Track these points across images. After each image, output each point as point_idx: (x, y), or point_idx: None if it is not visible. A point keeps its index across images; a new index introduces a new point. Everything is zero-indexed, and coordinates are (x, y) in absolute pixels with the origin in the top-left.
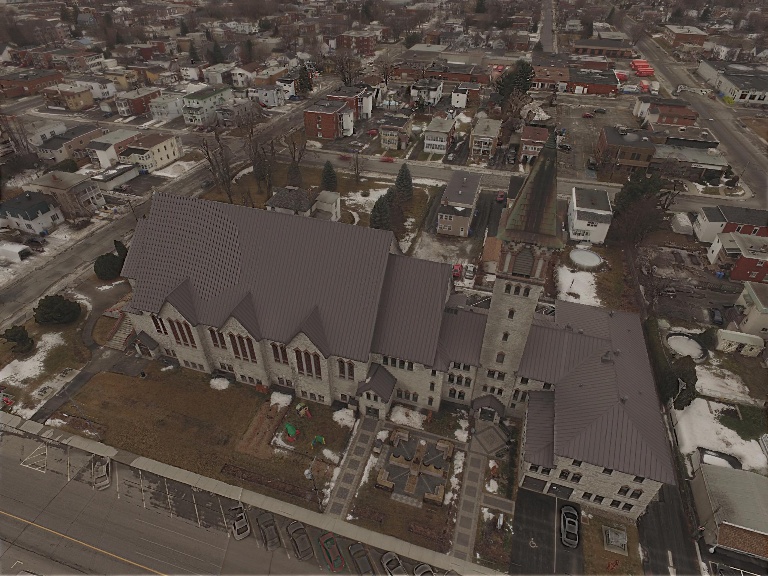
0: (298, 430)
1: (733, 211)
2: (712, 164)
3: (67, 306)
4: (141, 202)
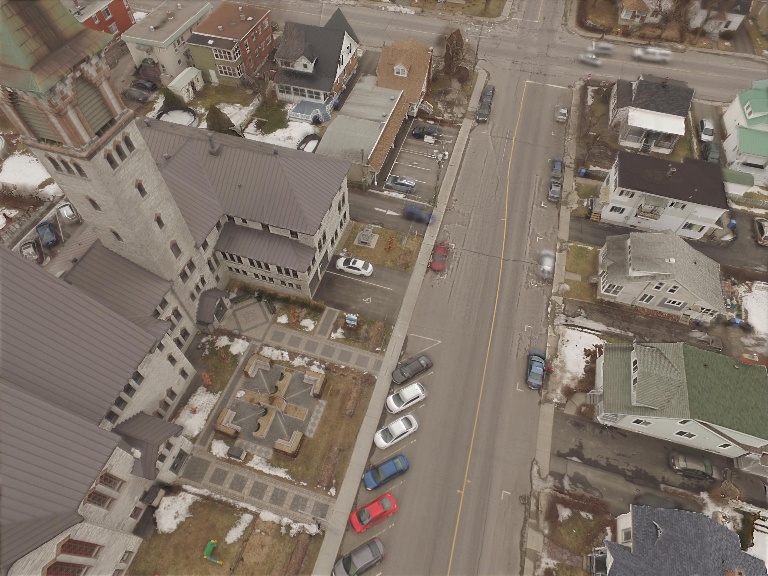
0: None
1: None
2: None
3: None
4: None
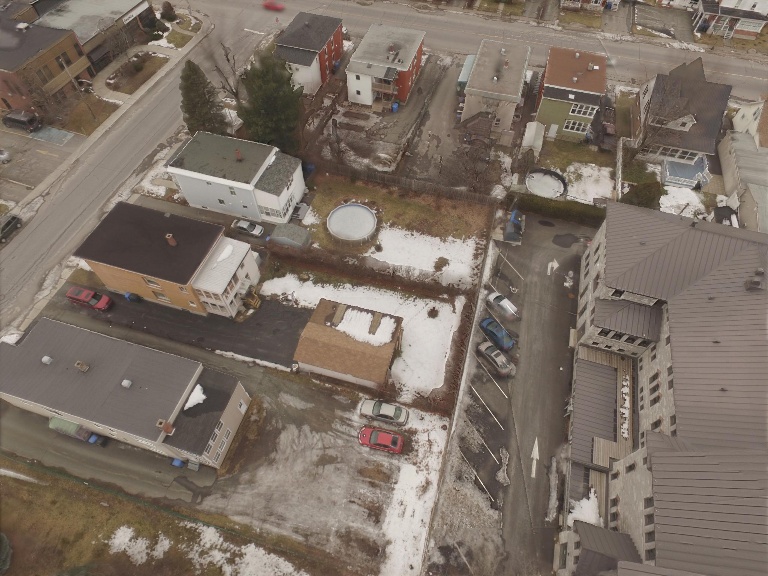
0: None
1: (301, 37)
2: (136, 5)
3: None
4: None
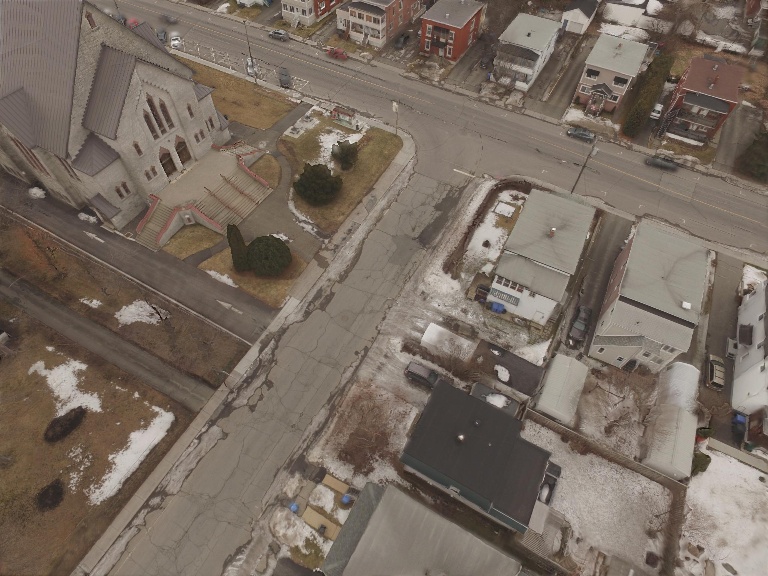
0: None
1: None
2: None
3: None
4: (234, 571)
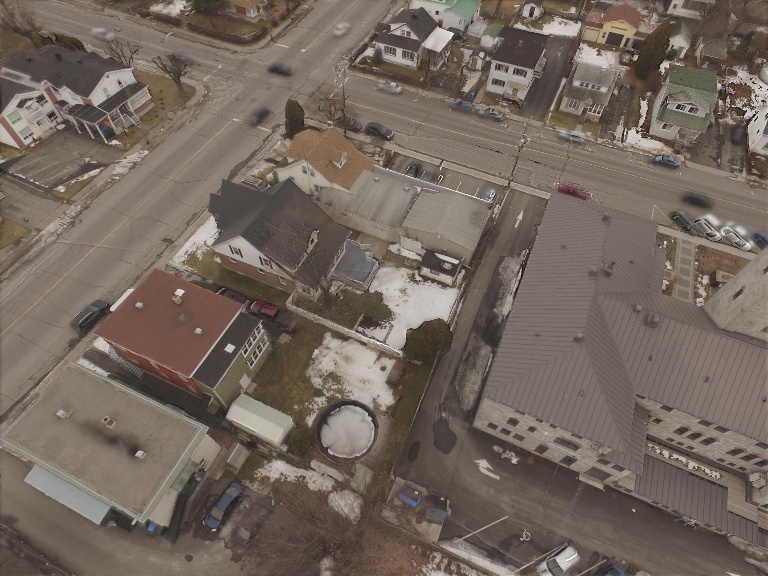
0: None
1: None
2: None
3: None
4: None
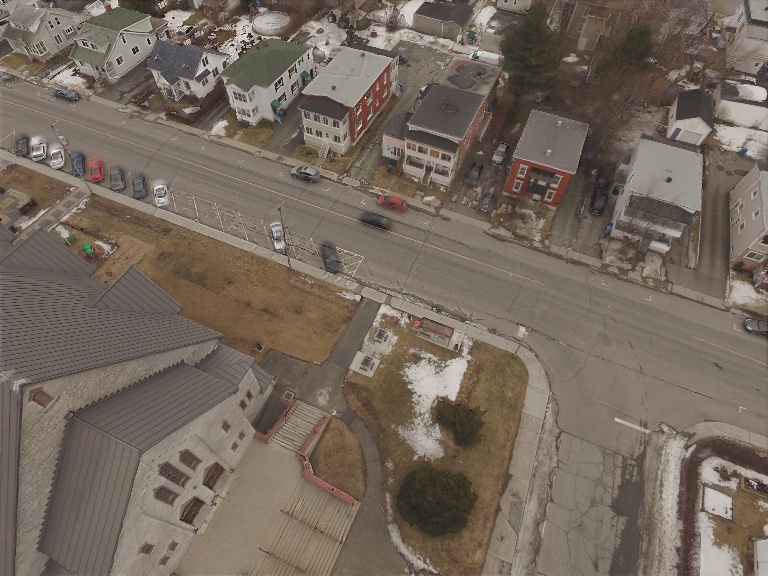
0: (83, 257)
1: None
2: None
3: (412, 491)
4: None
